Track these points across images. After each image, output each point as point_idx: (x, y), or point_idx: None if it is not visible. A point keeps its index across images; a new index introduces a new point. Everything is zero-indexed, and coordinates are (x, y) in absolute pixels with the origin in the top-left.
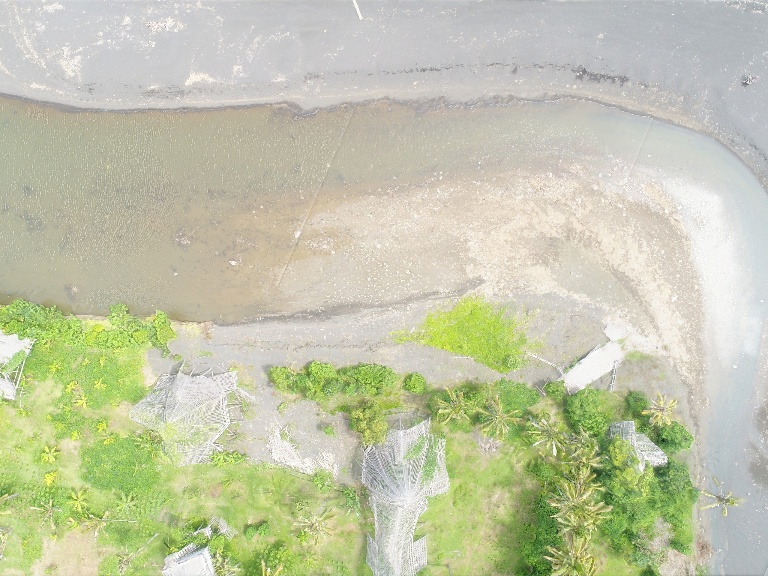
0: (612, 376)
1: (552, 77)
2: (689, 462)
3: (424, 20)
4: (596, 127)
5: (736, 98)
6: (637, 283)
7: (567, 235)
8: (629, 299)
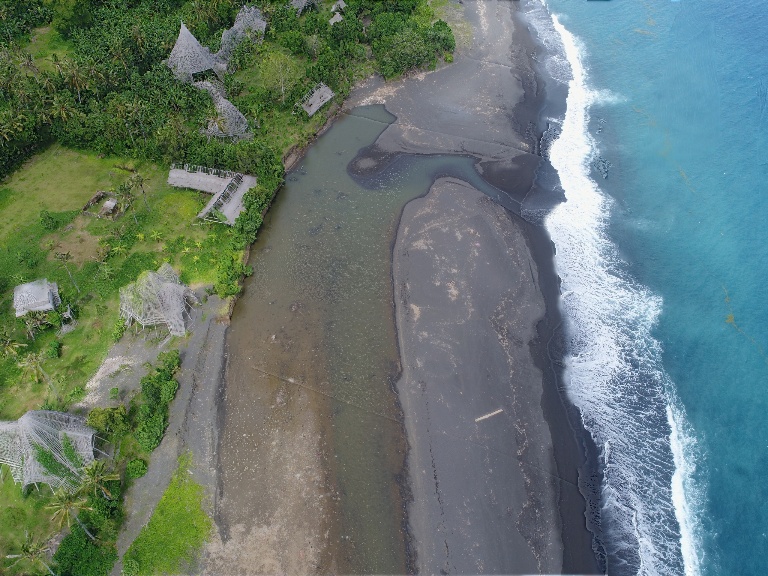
0: None
1: None
2: None
3: (482, 474)
4: None
5: None
6: None
7: None
8: None
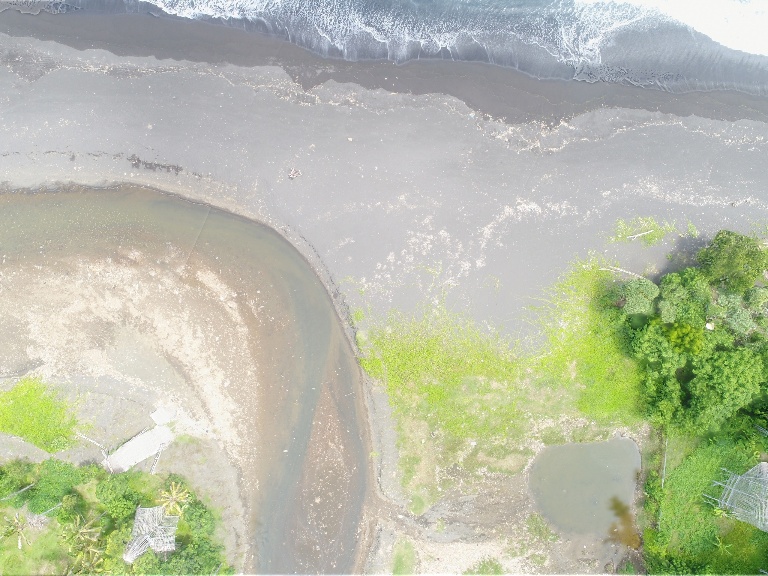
0: (155, 459)
1: (109, 165)
2: (226, 543)
3: None
4: (156, 214)
5: (283, 190)
6: (190, 368)
7: (123, 320)
8: (181, 384)
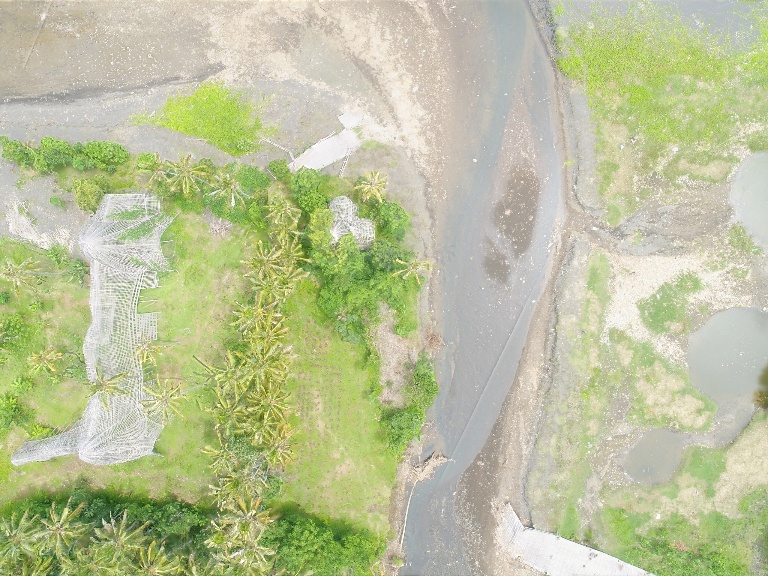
0: (343, 162)
1: None
2: (416, 250)
3: None
4: None
5: None
6: (378, 72)
7: (309, 21)
8: (369, 88)
